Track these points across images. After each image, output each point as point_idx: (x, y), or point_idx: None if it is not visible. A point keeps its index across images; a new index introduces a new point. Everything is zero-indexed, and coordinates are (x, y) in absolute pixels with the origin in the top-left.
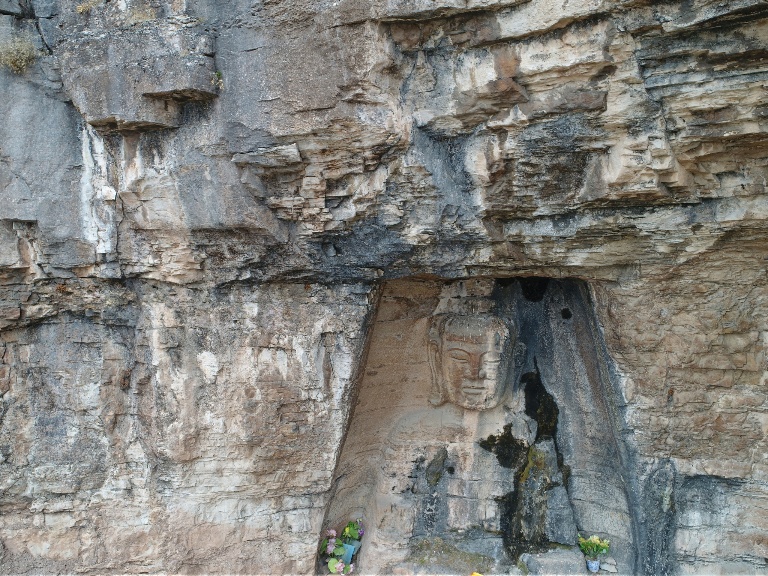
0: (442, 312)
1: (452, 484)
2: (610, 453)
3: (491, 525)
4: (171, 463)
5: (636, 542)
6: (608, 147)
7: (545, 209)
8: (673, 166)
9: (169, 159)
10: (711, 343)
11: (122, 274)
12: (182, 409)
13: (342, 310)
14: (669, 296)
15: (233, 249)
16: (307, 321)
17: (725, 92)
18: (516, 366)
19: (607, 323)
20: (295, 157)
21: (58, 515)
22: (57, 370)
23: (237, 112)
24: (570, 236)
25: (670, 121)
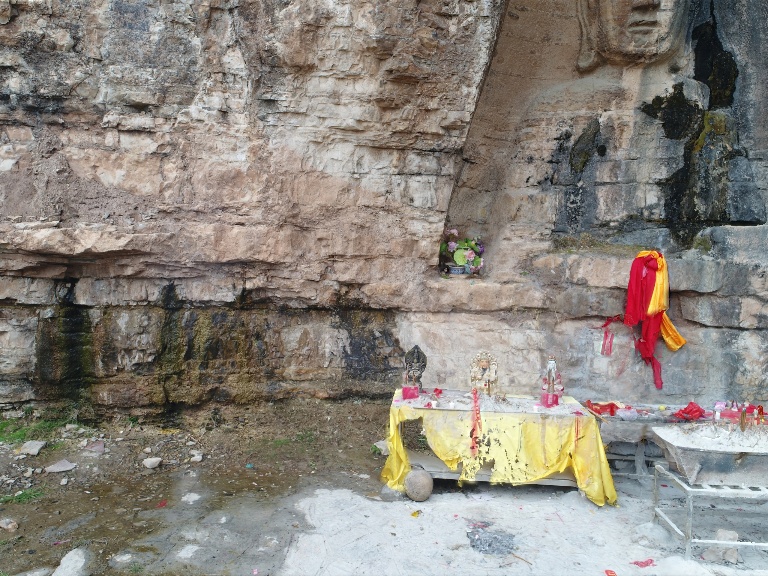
0: None
1: (602, 169)
2: None
3: (653, 212)
4: (279, 73)
5: None
6: None
7: None
8: None
9: None
10: None
11: None
12: None
13: None
14: None
15: None
16: None
17: None
18: (690, 10)
19: None
20: None
21: (136, 136)
22: None
23: None
24: None
25: None
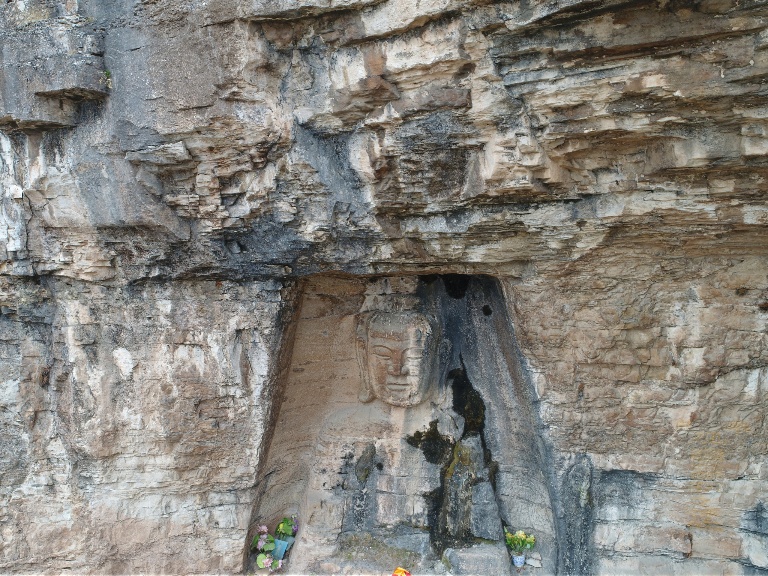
0: (369, 309)
1: (381, 480)
2: (534, 449)
3: (419, 521)
4: (91, 459)
5: (556, 537)
6: (483, 144)
7: (435, 206)
8: (543, 162)
9: (68, 157)
10: (614, 338)
11: (34, 272)
12: (99, 405)
13: (255, 307)
14: (570, 292)
15: (139, 246)
16: (221, 318)
17: (577, 89)
18: (442, 363)
19: (515, 319)
20: (182, 155)
21: None
22: None
23: (126, 110)
24: (464, 232)
25: (534, 118)
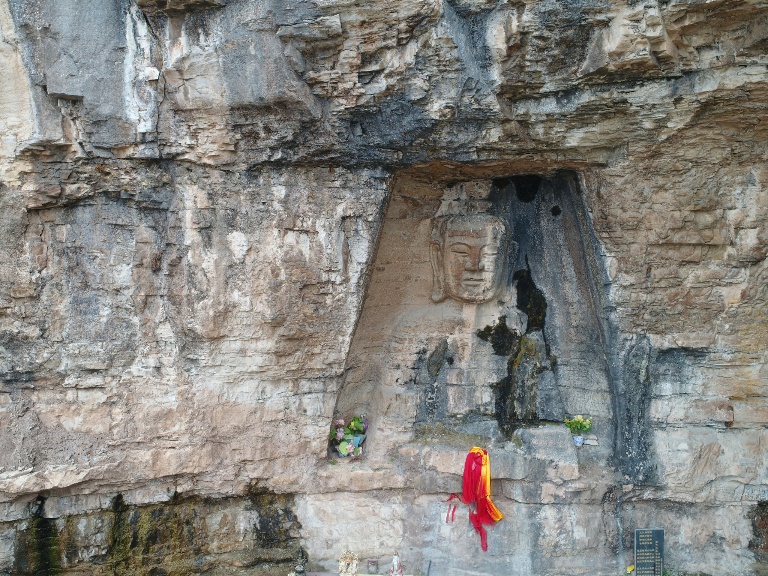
0: (443, 214)
1: (451, 374)
2: (592, 339)
3: (487, 409)
4: (199, 341)
5: (616, 413)
6: (609, 20)
7: (551, 85)
8: (663, 34)
9: (215, 36)
10: (684, 219)
11: (160, 154)
12: (212, 287)
13: (362, 194)
14: (650, 175)
15: (268, 127)
16: (330, 204)
17: None
18: (510, 263)
19: (596, 205)
20: (338, 27)
21: (90, 391)
22: (92, 250)
23: None
24: (570, 113)
25: None
